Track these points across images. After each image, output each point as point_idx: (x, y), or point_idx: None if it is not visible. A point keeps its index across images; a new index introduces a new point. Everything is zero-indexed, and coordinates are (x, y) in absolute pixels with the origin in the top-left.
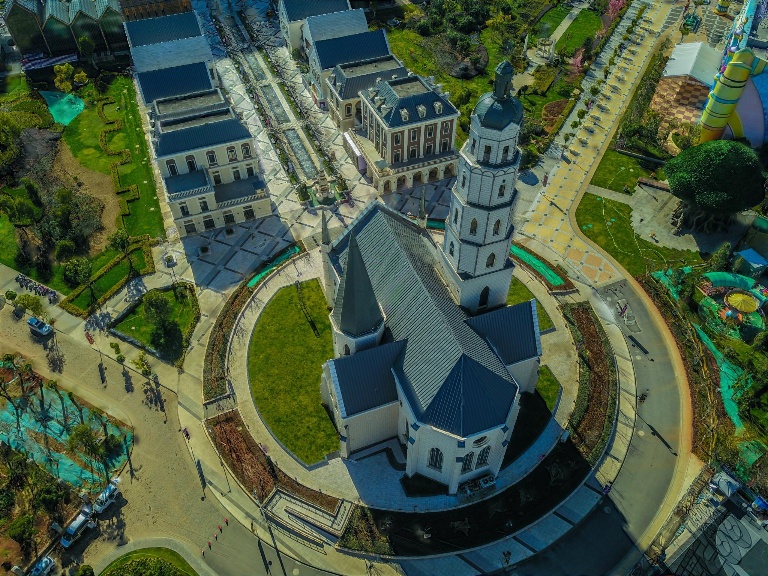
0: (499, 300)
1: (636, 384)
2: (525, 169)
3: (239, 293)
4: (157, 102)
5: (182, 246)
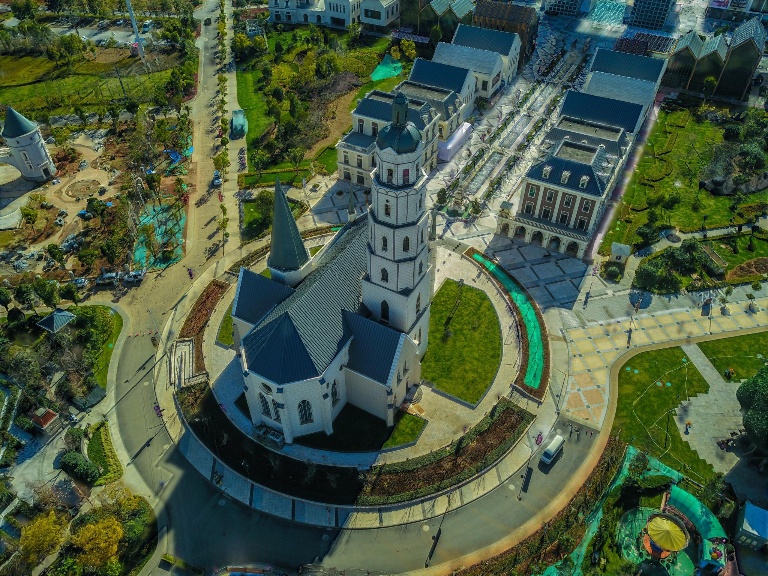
0: (400, 325)
1: (478, 499)
2: (648, 291)
3: (322, 229)
4: (405, 82)
5: (333, 184)
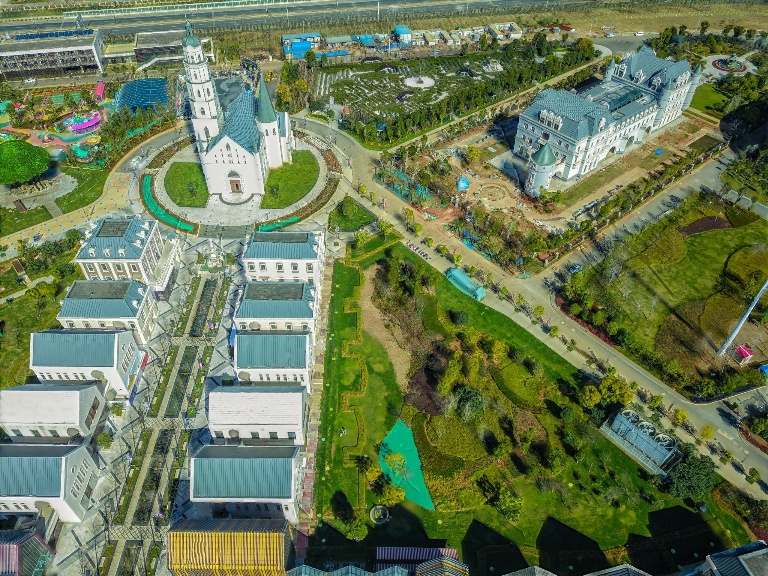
0: None
1: None
2: None
3: None
4: None
5: (326, 253)
